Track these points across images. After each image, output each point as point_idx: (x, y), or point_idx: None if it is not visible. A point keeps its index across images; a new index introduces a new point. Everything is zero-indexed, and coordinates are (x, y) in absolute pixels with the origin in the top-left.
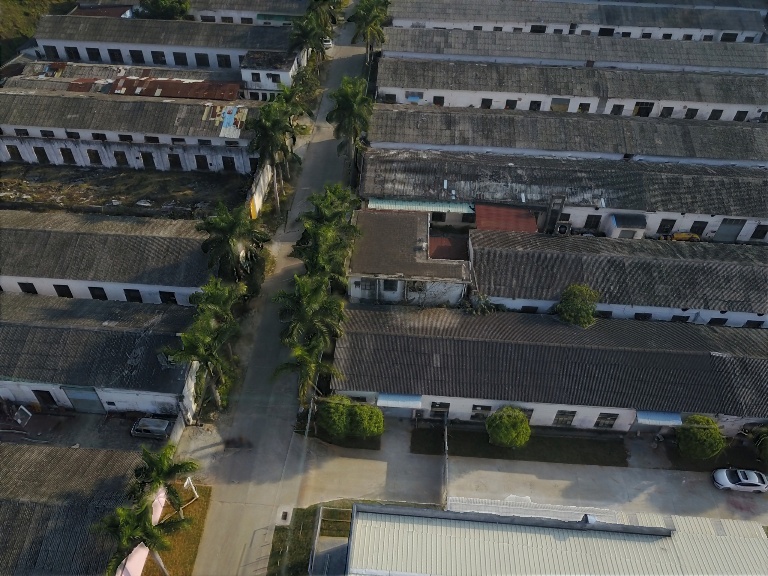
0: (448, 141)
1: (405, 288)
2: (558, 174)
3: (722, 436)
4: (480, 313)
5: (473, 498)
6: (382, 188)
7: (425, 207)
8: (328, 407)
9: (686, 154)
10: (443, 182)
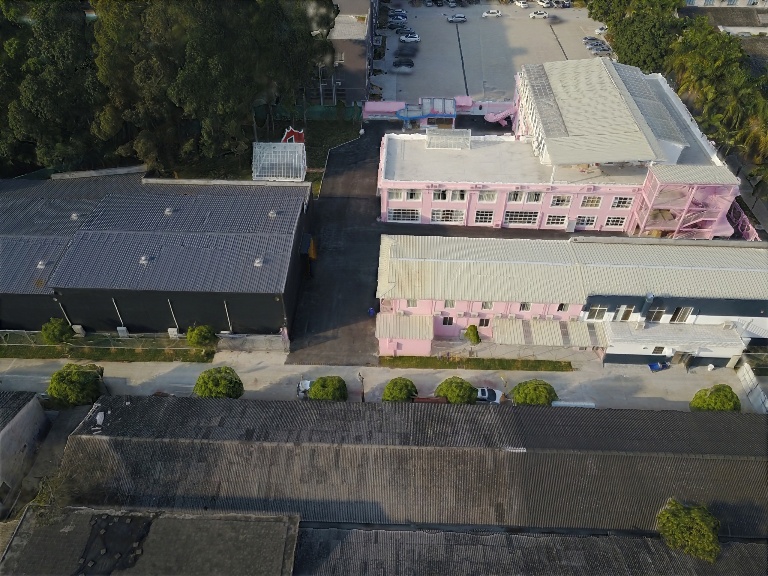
0: None
1: None
2: None
3: (511, 400)
4: None
5: (726, 347)
6: None
7: None
8: None
9: None
10: None
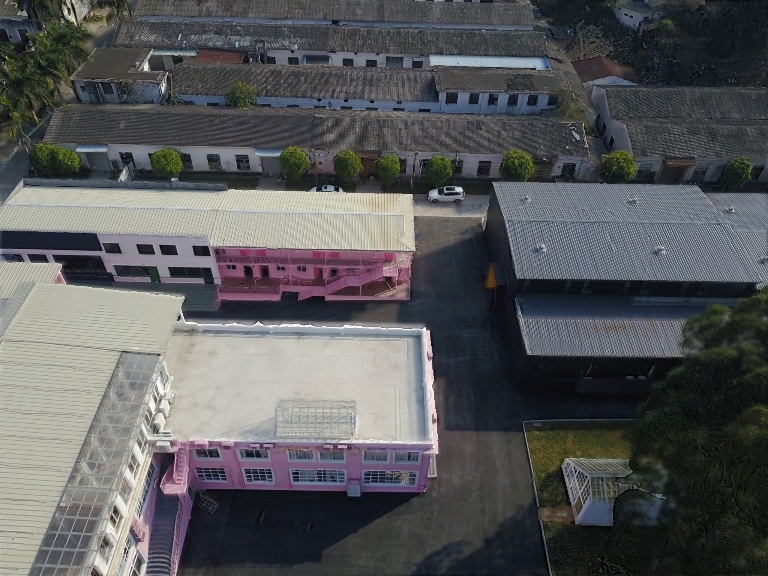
0: (196, 14)
1: (118, 90)
2: (267, 29)
3: (311, 162)
4: (171, 104)
5: None
6: (130, 40)
7: (162, 53)
8: (35, 148)
9: (377, 19)
10: (178, 36)
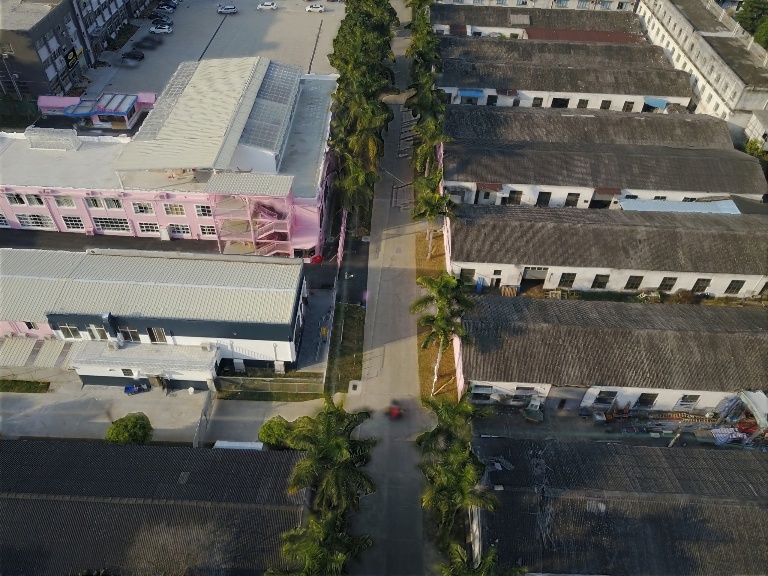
0: None
1: None
2: None
3: None
4: (93, 573)
5: (190, 370)
6: None
7: None
8: None
9: None
10: None
